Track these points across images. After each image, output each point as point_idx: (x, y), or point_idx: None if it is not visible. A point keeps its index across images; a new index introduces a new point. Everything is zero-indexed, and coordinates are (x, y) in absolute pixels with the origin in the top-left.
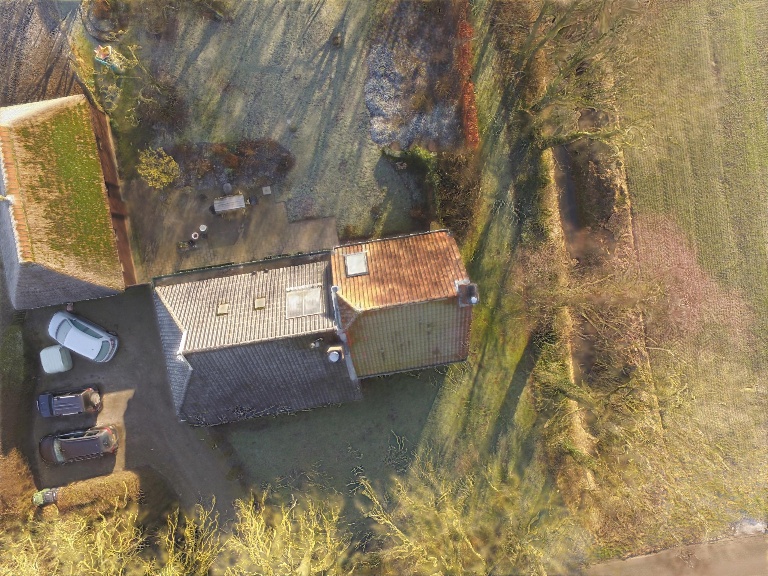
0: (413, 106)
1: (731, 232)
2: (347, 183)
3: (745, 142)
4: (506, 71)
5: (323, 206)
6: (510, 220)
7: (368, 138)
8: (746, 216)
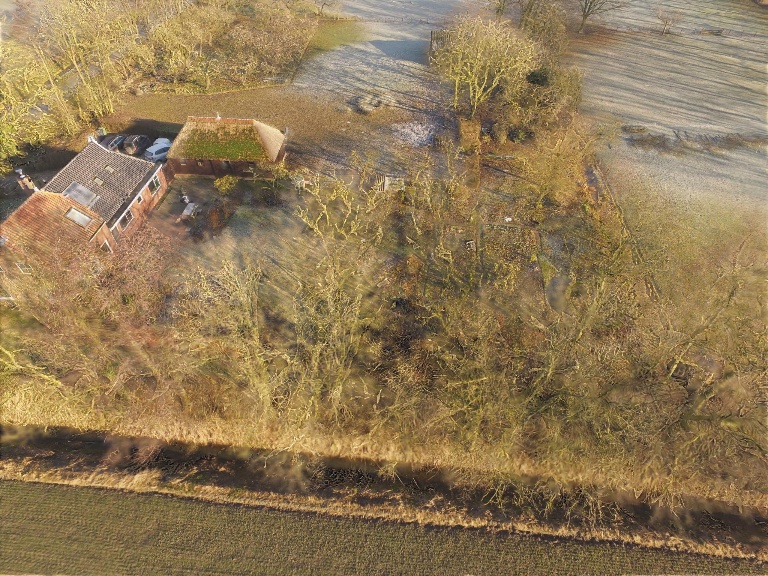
0: None
1: None
2: None
3: None
4: None
5: None
6: None
7: None
8: None
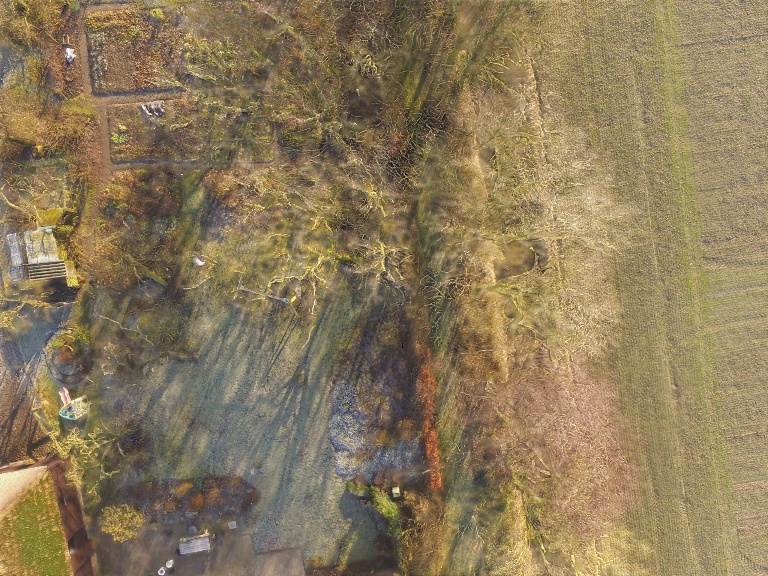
0: (377, 440)
1: (692, 549)
2: (312, 515)
3: (705, 463)
4: (469, 400)
5: (288, 539)
6: (474, 543)
7: (333, 472)
8: (707, 534)
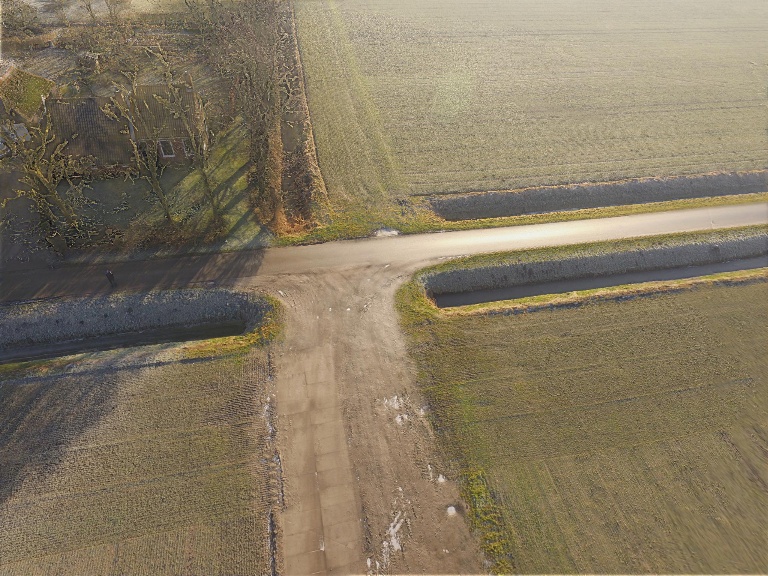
0: None
1: None
2: None
3: (366, 112)
4: None
5: None
6: None
7: None
8: None
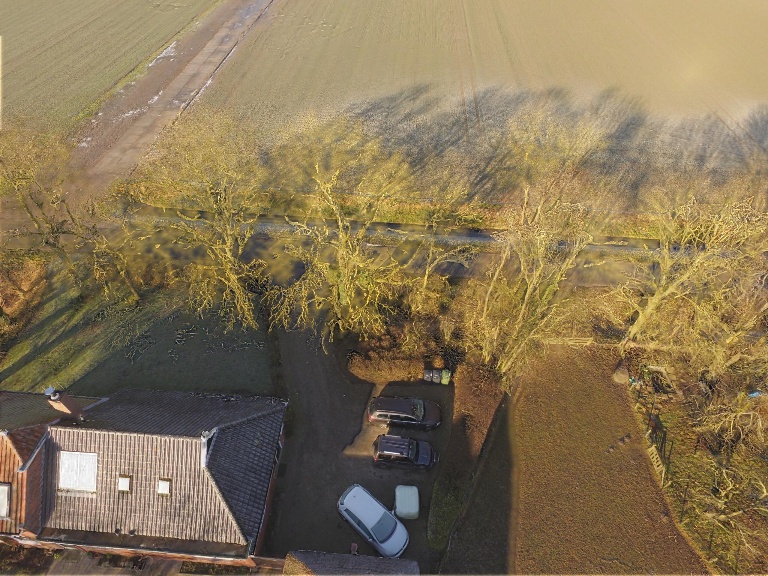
0: None
1: None
2: None
3: None
4: None
5: None
6: None
7: None
8: None
